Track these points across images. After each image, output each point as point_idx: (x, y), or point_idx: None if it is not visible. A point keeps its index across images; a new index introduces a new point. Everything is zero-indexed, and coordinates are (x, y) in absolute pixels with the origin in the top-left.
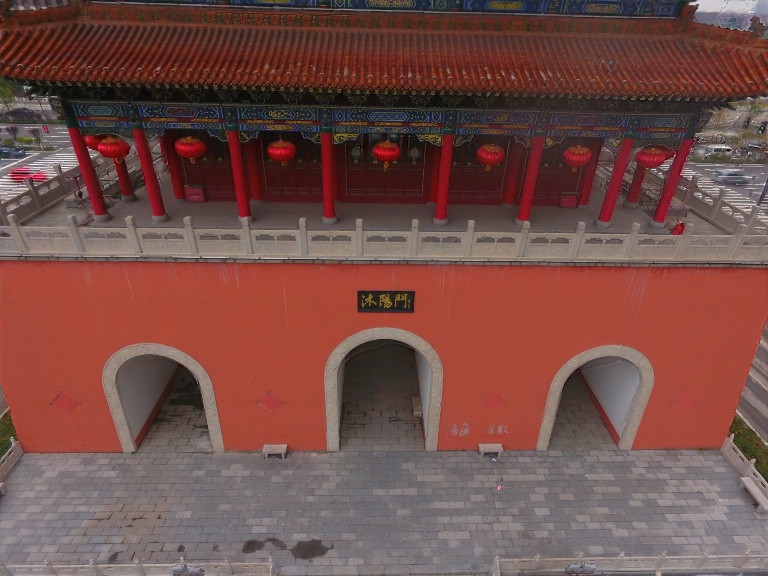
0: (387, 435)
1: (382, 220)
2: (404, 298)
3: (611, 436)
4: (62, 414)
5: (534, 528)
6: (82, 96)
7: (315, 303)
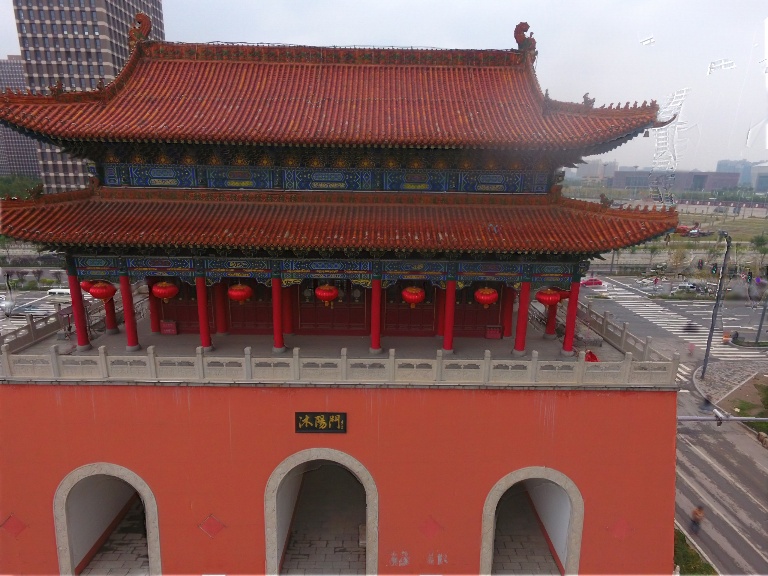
0: (329, 566)
1: (325, 350)
2: (337, 419)
3: (558, 569)
4: (9, 538)
5: None
6: (84, 252)
7: (257, 424)
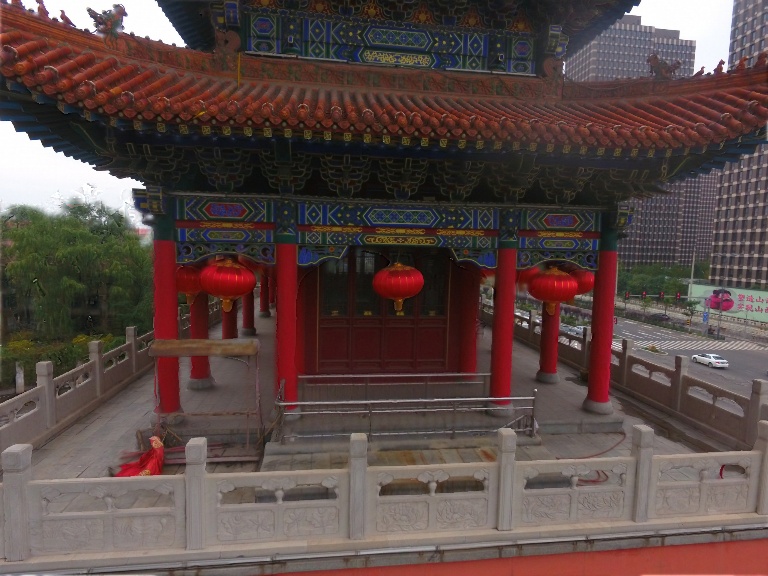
0: None
1: (264, 324)
2: None
3: None
4: None
5: None
6: None
7: None
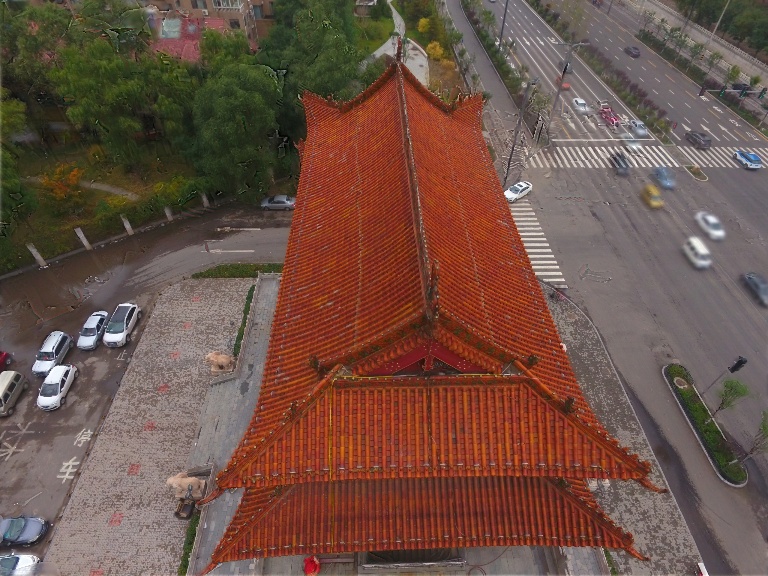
0: None
1: None
2: None
3: None
4: None
5: (232, 494)
6: None
7: None
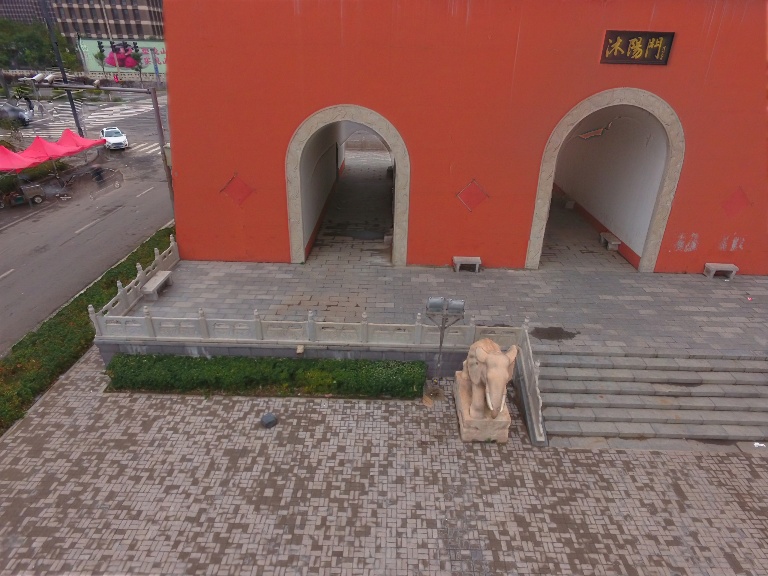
0: (586, 261)
1: None
2: (658, 44)
3: None
4: (231, 206)
5: None
6: None
7: (552, 49)
